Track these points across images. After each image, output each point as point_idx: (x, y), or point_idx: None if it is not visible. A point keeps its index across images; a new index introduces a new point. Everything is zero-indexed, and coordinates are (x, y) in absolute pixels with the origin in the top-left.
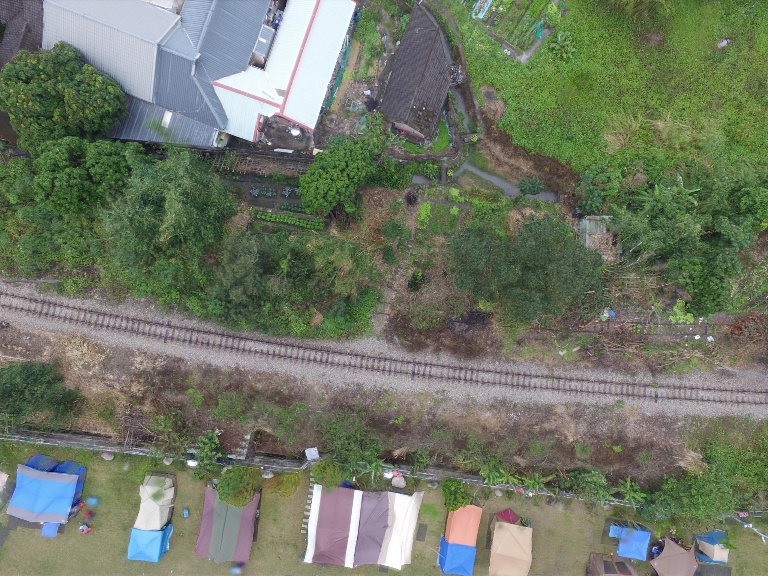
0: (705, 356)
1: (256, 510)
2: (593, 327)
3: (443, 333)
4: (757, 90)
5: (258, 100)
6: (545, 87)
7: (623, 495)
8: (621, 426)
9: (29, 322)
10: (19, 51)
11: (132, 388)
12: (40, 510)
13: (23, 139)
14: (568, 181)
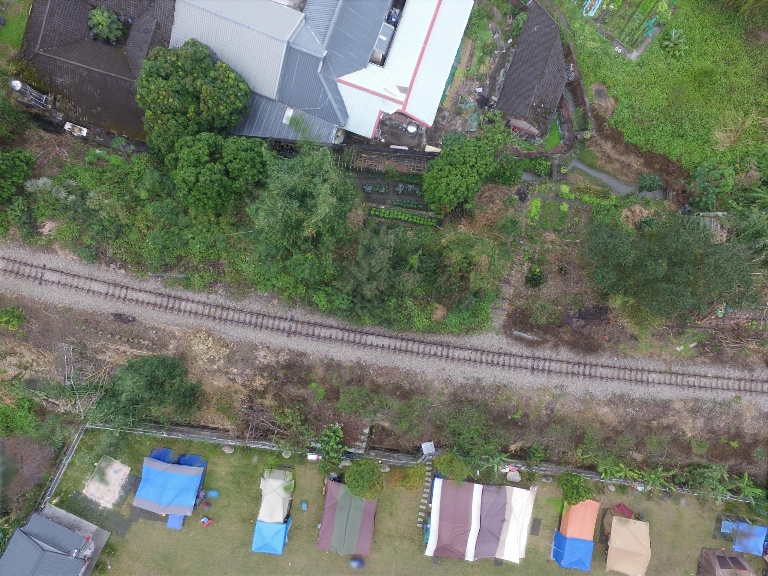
0: None
1: (377, 503)
2: (709, 323)
3: (562, 328)
4: None
5: (381, 97)
6: (656, 84)
7: (735, 491)
8: (738, 422)
9: (155, 316)
10: (156, 48)
11: (253, 382)
12: (167, 502)
13: (156, 135)
14: (677, 178)
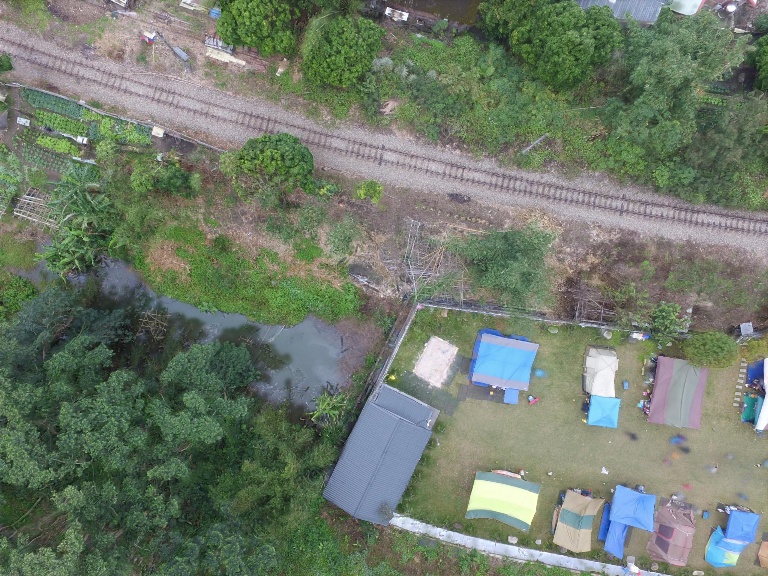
0: None
1: None
2: None
3: None
4: None
5: None
6: None
7: None
8: None
9: (490, 196)
10: None
11: (580, 263)
12: (508, 377)
13: (507, 8)
14: None
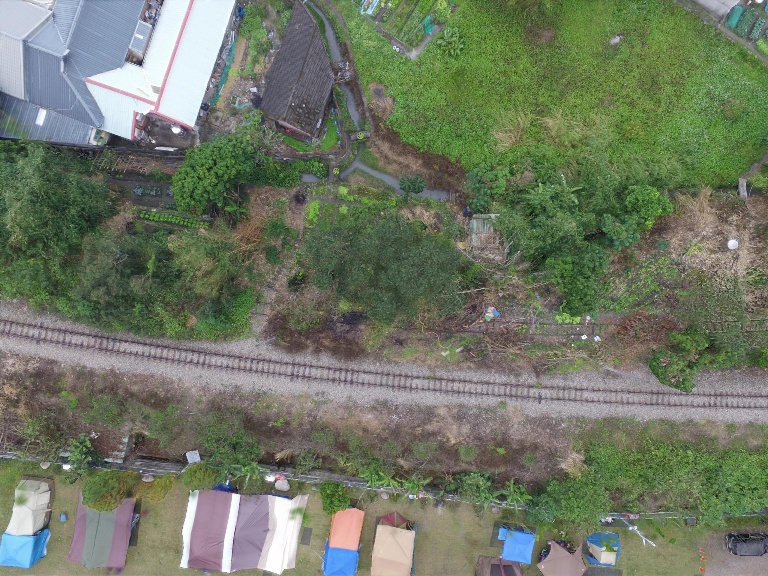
0: (589, 356)
1: (132, 514)
2: (478, 327)
3: (322, 334)
4: (650, 87)
5: (132, 97)
6: (434, 84)
7: None
8: (505, 427)
9: None
10: None
11: None
12: None
13: None
14: (459, 179)
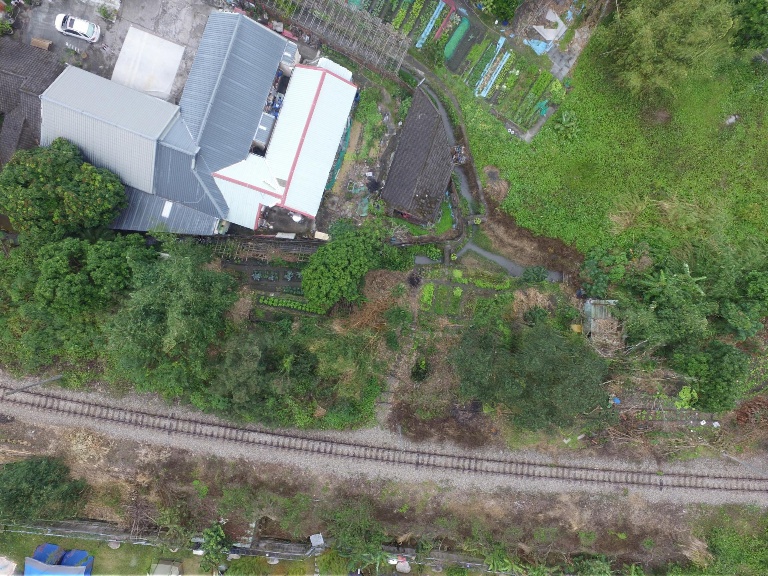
0: (711, 444)
1: None
2: (598, 413)
3: (447, 423)
4: (766, 167)
5: (259, 191)
6: (549, 167)
7: None
8: (626, 513)
9: (34, 416)
10: (18, 152)
11: None
12: None
13: (24, 238)
14: (573, 261)
